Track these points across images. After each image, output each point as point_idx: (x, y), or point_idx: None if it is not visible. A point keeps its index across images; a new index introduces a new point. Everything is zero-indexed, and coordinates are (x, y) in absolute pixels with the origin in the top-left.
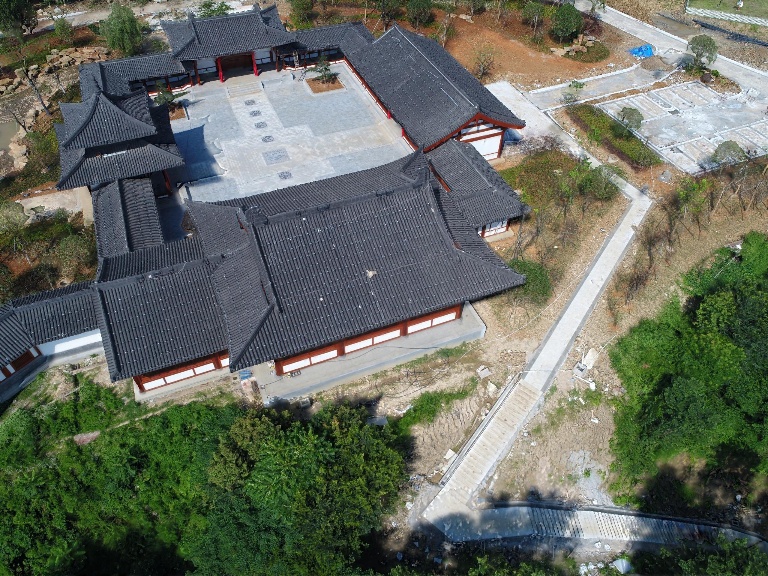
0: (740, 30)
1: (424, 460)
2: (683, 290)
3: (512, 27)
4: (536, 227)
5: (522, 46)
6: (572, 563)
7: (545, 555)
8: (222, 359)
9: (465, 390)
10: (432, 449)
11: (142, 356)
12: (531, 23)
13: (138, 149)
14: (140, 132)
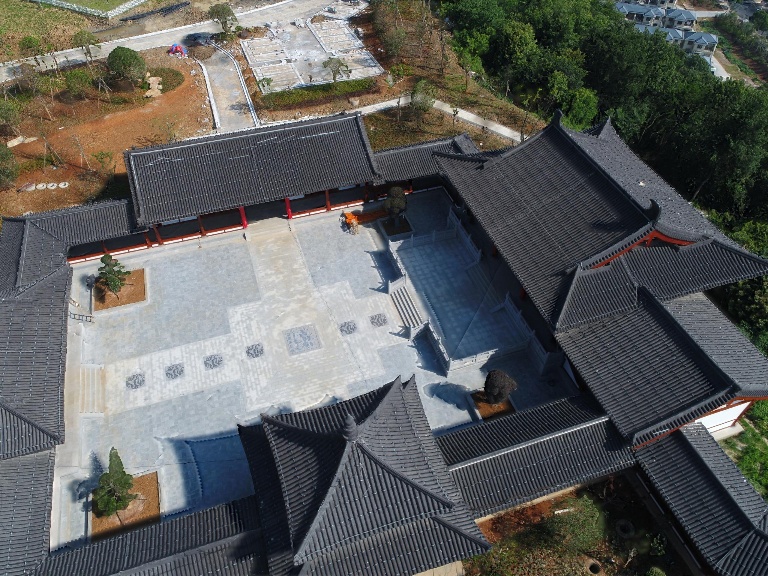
0: (154, 6)
1: None
2: None
3: None
4: None
5: (125, 113)
6: None
7: None
8: None
9: None
10: None
11: (761, 366)
12: (84, 95)
13: None
14: (400, 402)
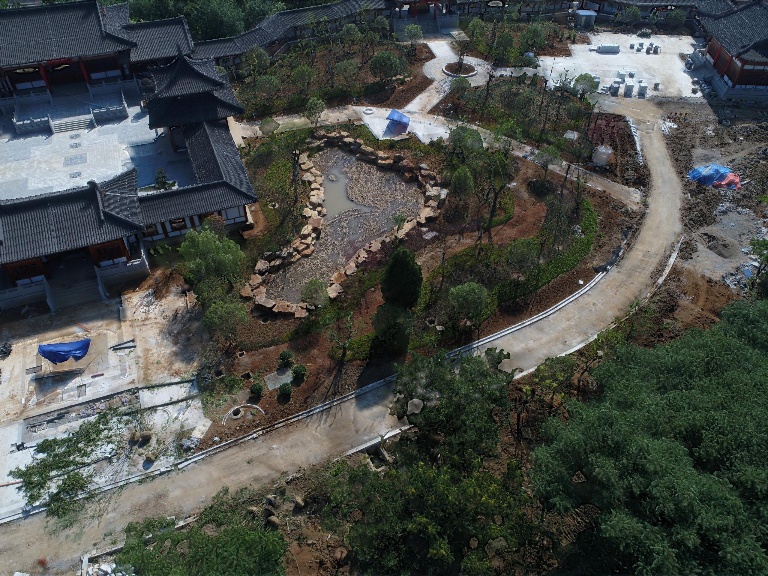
0: None
1: None
2: None
3: None
4: None
5: None
6: None
7: None
8: None
9: None
10: None
11: None
12: None
13: None
14: None
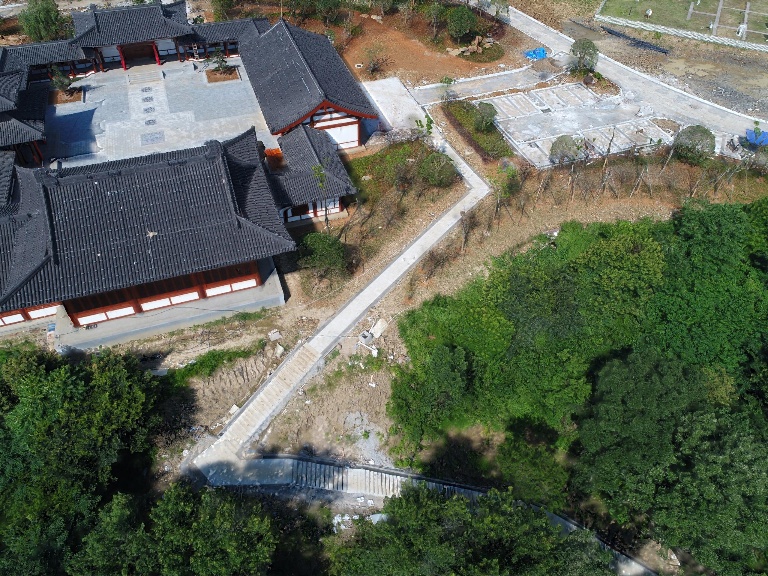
0: (644, 37)
1: (206, 412)
2: (490, 271)
3: (417, 28)
4: (370, 209)
5: (421, 46)
6: (327, 513)
7: (301, 504)
8: (29, 311)
9: (249, 349)
10: (214, 402)
11: None
12: None
13: (3, 123)
14: (1, 107)
